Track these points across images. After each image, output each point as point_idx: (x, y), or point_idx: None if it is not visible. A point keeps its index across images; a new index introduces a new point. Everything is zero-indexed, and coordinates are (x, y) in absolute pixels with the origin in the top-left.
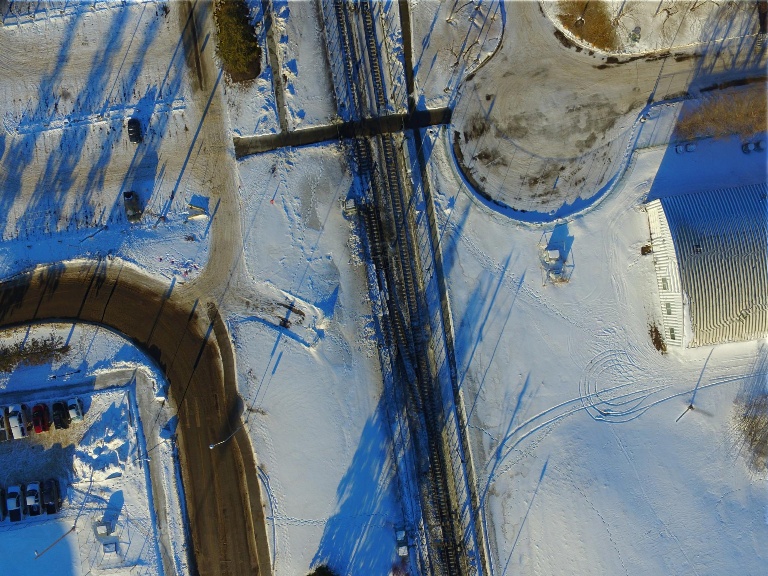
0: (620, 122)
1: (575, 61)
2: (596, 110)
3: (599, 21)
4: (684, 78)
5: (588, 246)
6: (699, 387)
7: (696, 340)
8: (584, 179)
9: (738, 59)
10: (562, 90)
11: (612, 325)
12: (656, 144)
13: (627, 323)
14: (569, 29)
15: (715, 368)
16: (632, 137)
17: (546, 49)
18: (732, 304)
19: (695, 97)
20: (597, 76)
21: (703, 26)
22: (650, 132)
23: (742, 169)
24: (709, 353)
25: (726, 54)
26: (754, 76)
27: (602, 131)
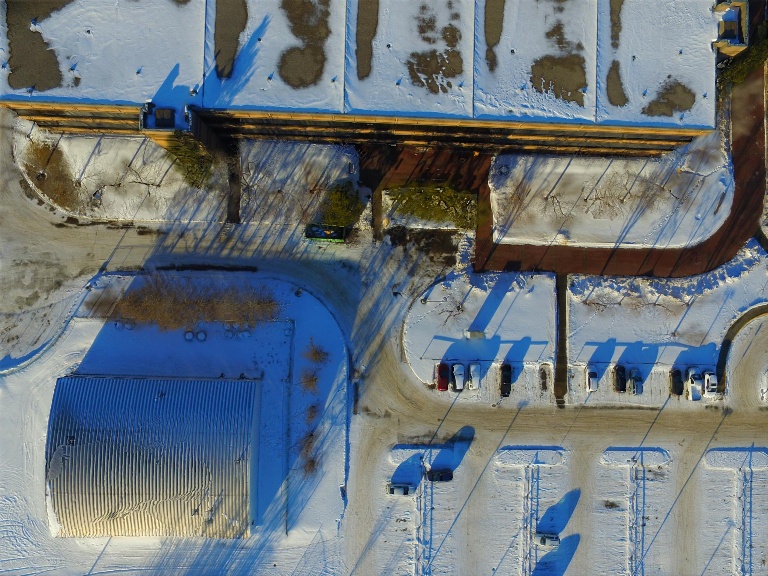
0: (67, 285)
1: (34, 214)
2: (44, 269)
3: (60, 179)
4: (142, 252)
5: (5, 408)
6: (94, 572)
7: (65, 531)
8: (18, 337)
9: (201, 243)
10: (13, 241)
11: (14, 494)
12: (96, 315)
13: (30, 495)
14: (33, 180)
15: (113, 555)
16: (75, 303)
17: (7, 196)
18: (132, 495)
19: (150, 274)
20: (52, 234)
21: (169, 204)
22: (93, 302)
23: (180, 356)
24: (108, 539)
25: (190, 236)
26: (214, 264)
27: (46, 291)
